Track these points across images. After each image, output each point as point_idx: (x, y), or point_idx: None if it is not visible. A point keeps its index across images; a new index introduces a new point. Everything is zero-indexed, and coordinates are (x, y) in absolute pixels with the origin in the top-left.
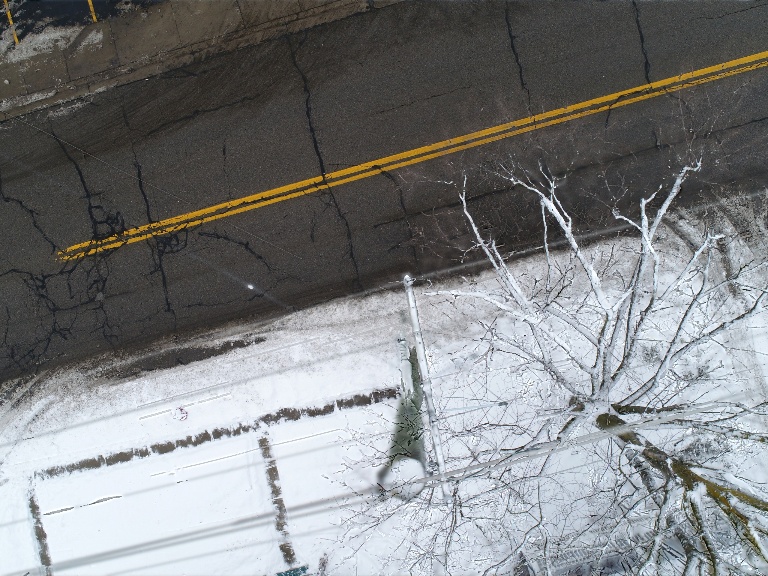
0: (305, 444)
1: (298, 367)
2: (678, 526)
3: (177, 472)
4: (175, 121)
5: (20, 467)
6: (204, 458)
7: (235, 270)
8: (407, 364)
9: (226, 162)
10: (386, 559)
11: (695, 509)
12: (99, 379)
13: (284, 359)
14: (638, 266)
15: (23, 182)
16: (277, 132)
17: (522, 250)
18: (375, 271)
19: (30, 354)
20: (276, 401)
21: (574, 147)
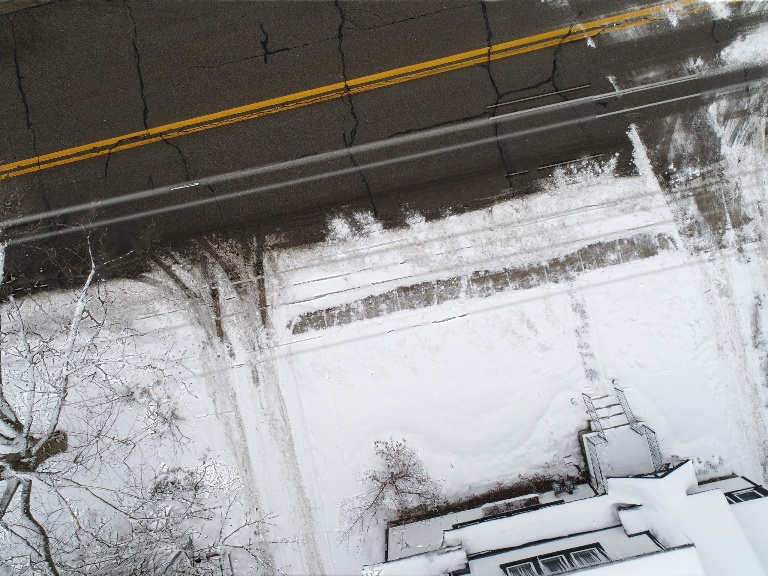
0: None
1: None
2: None
3: None
4: None
5: None
6: None
7: None
8: None
9: None
10: None
11: None
12: None
13: None
14: None
15: None
16: None
17: (28, 287)
18: None
19: None
20: None
21: (76, 189)
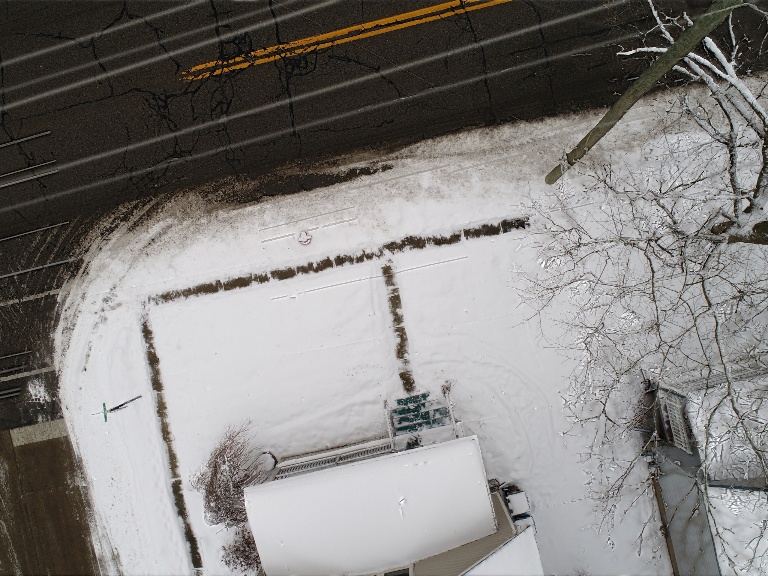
0: (432, 270)
1: (427, 194)
2: None
3: (299, 296)
4: None
5: (134, 291)
6: (327, 282)
7: (364, 95)
8: None
9: None
10: (567, 323)
11: None
12: (219, 203)
13: (413, 185)
14: None
15: None
16: None
17: (661, 82)
18: (509, 100)
19: (149, 176)
20: (402, 228)
21: None
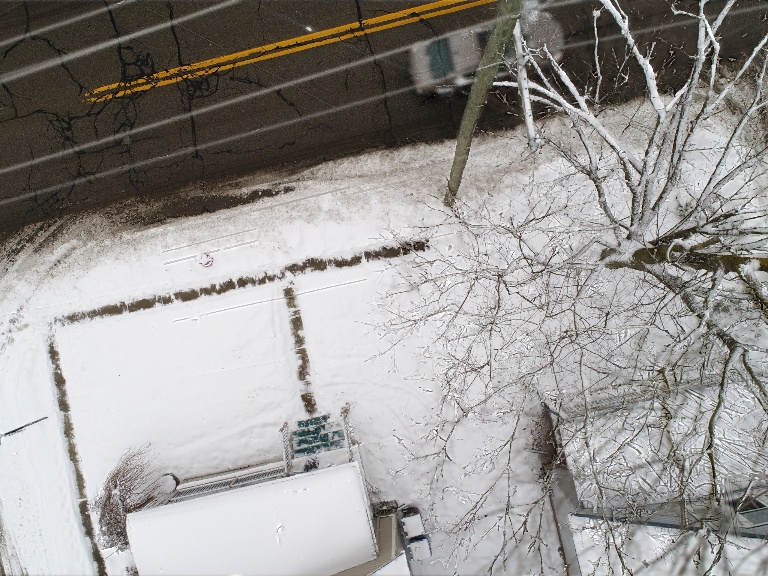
0: (331, 293)
1: (327, 216)
2: None
3: (200, 318)
4: None
5: (40, 312)
6: (228, 304)
7: (266, 117)
8: None
9: (261, 5)
10: None
11: (748, 279)
12: (123, 225)
13: (313, 207)
14: (688, 84)
15: (51, 20)
16: None
17: None
18: (409, 122)
19: (54, 198)
20: (303, 250)
21: None
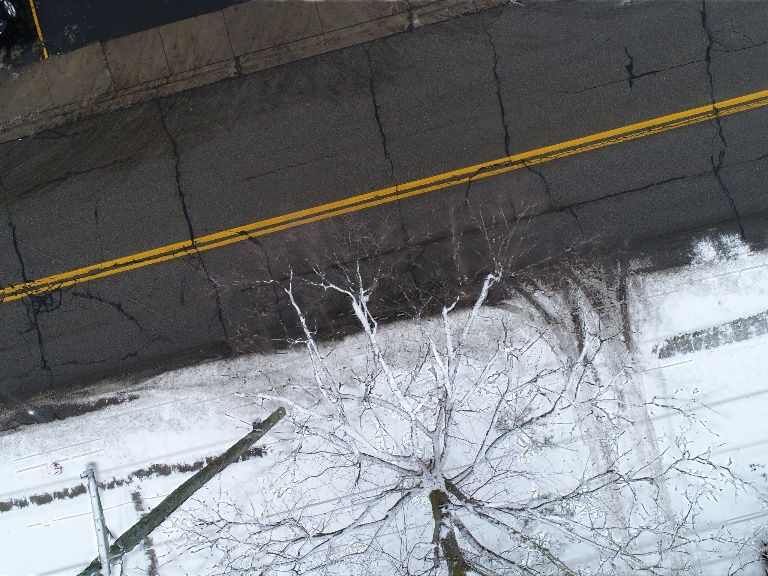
0: None
1: (168, 426)
2: None
3: (53, 523)
4: (48, 182)
5: None
6: (78, 511)
7: (108, 330)
8: None
9: (98, 224)
10: None
11: None
12: None
13: (154, 418)
14: (455, 361)
15: None
16: (147, 196)
17: (384, 317)
18: None
19: None
20: (147, 457)
21: (435, 218)
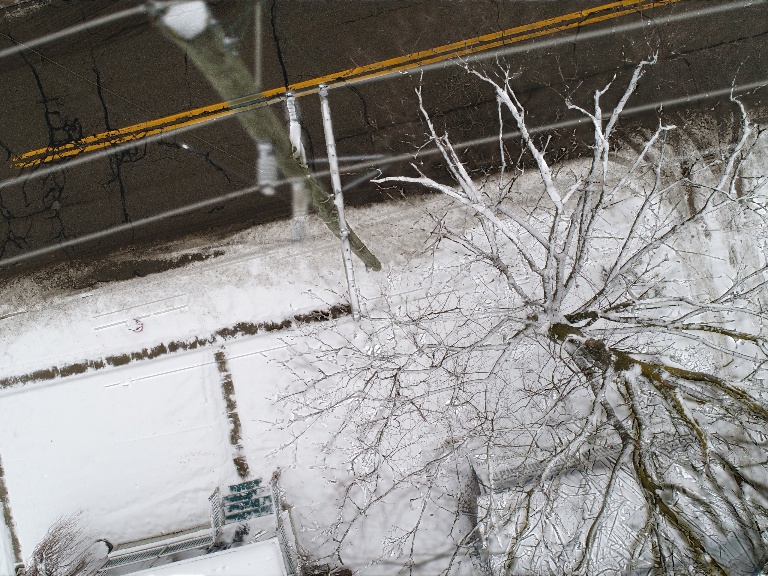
0: (261, 358)
1: (256, 281)
2: (617, 419)
3: (131, 384)
4: (136, 26)
5: None
6: (159, 370)
7: (195, 181)
8: (296, 125)
9: (187, 70)
10: None
11: (628, 387)
12: (54, 290)
13: (242, 272)
14: None
15: None
16: (240, 40)
17: None
18: None
19: None
20: (233, 315)
21: (542, 64)
